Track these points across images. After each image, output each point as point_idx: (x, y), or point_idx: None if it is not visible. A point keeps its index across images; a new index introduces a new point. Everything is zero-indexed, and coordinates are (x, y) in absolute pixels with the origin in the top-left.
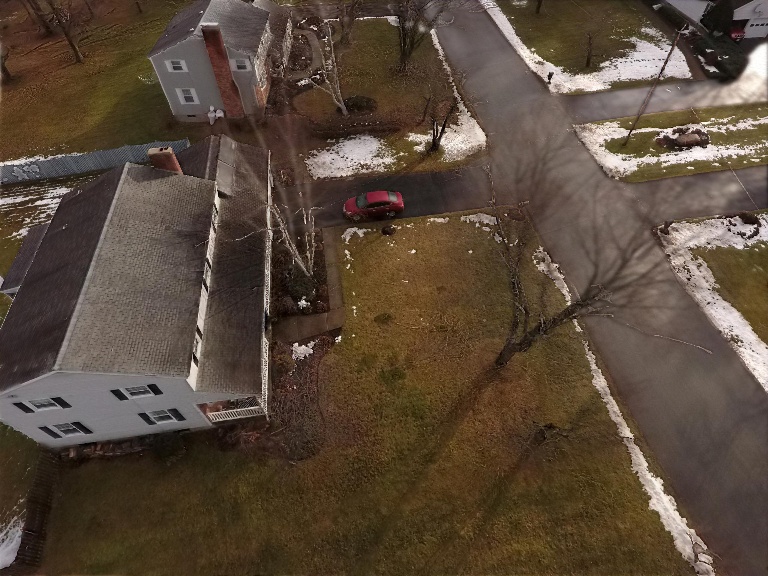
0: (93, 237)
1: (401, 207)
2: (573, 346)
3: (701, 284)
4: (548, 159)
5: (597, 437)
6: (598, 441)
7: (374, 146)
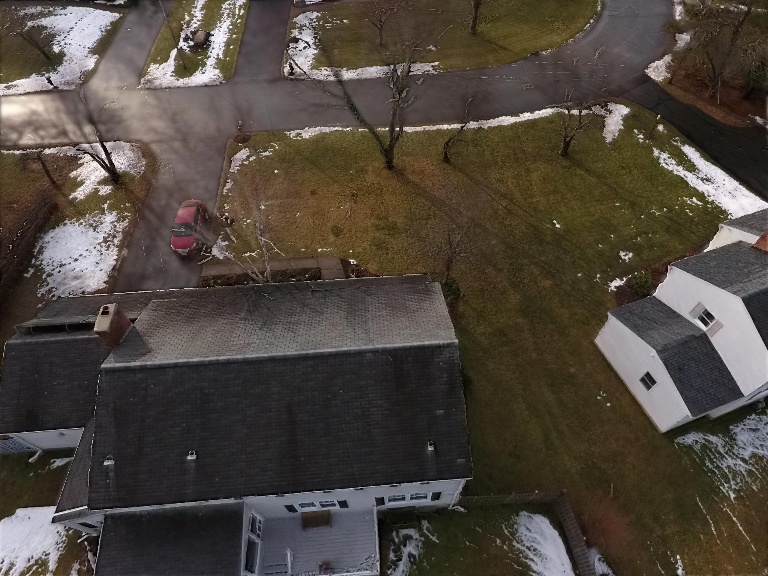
0: (256, 373)
1: (205, 204)
2: (381, 134)
3: (342, 73)
4: (179, 110)
5: (447, 137)
6: (449, 137)
7: (73, 229)
